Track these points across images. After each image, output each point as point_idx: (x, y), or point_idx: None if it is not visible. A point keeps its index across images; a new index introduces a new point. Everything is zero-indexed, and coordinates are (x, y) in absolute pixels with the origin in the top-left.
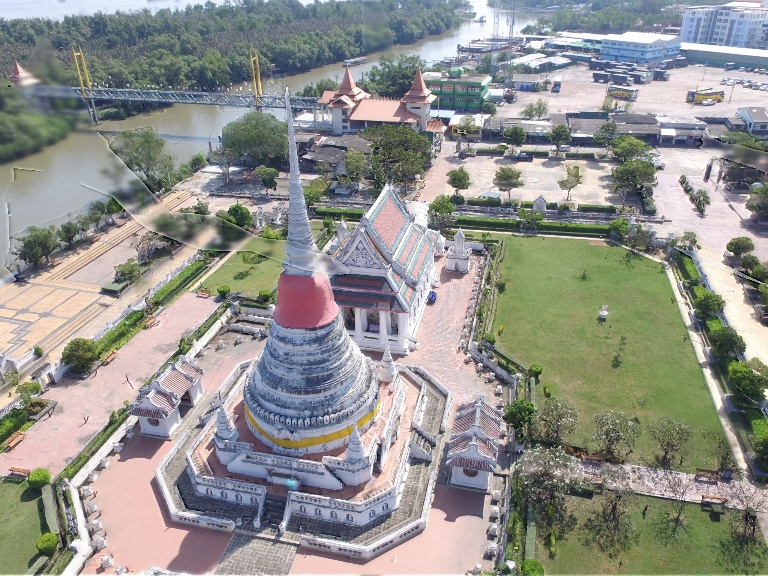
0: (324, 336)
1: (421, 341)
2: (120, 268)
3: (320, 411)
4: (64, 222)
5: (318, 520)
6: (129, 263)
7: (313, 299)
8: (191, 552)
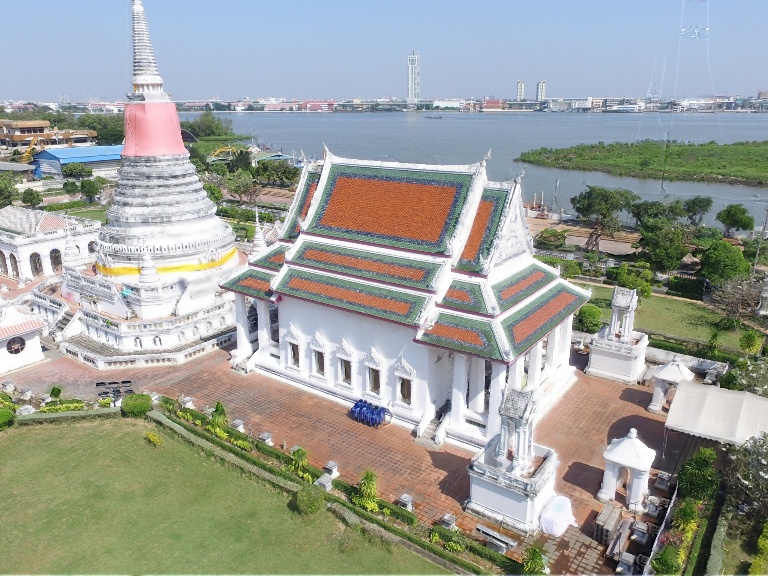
0: None
1: (248, 378)
2: (549, 230)
3: None
4: (652, 199)
5: None
6: None
7: None
8: None
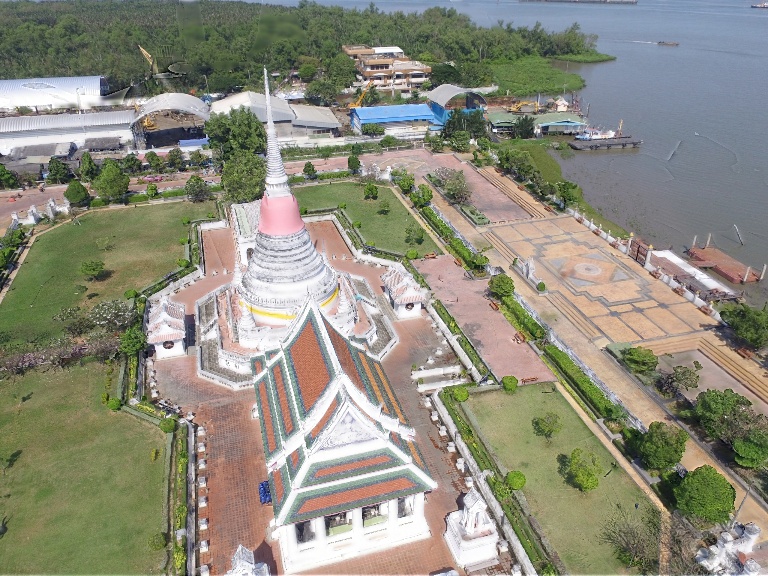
0: None
1: (252, 423)
2: (641, 349)
3: None
4: None
5: None
6: (647, 358)
7: None
8: None
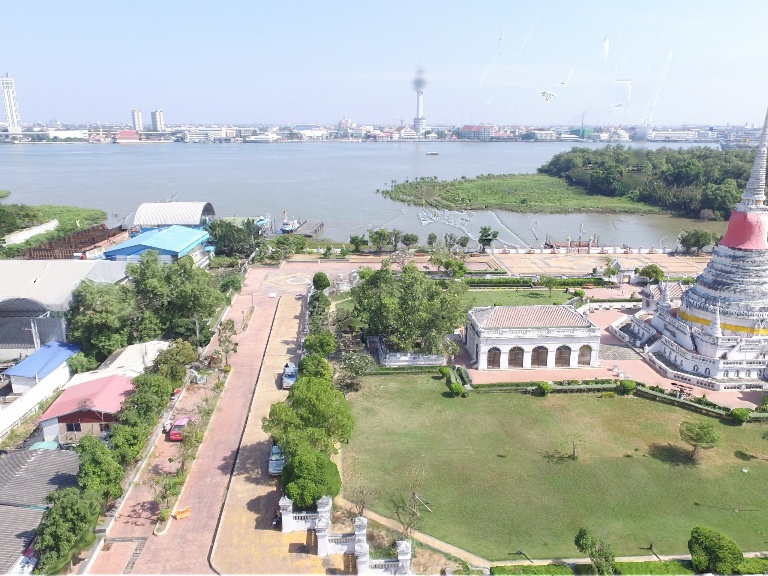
0: (739, 257)
1: None
2: None
3: (711, 302)
4: None
5: (667, 359)
6: None
7: (742, 229)
8: (601, 337)
